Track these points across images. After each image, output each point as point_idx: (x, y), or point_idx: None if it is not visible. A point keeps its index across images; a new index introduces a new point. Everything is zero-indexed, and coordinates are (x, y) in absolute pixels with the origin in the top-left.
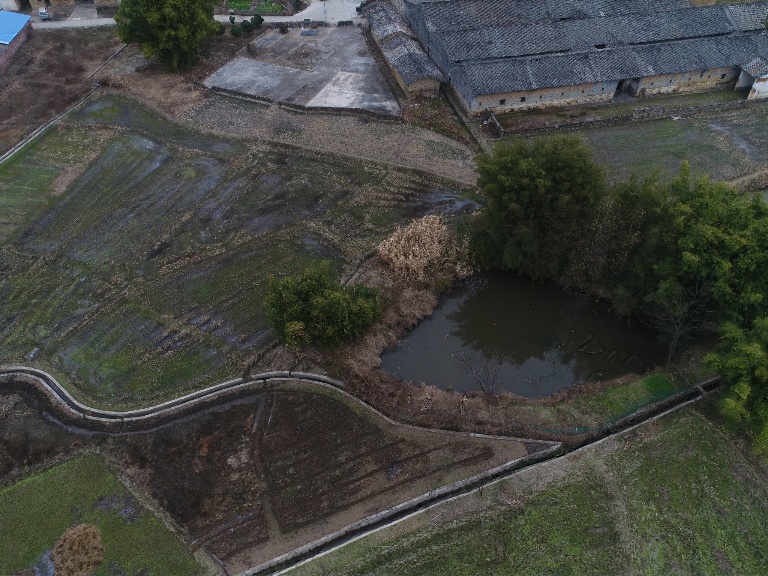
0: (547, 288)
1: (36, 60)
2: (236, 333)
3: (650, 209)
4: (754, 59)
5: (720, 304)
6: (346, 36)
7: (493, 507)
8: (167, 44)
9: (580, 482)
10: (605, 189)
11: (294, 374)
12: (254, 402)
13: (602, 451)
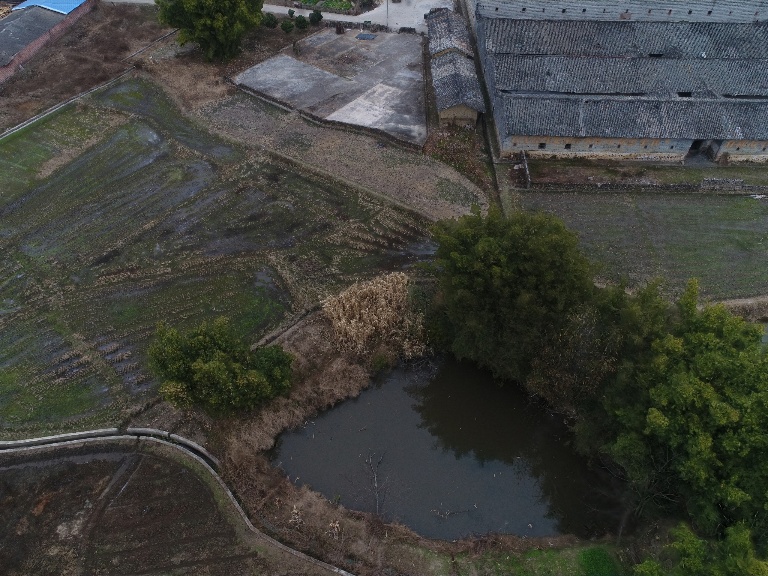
0: (508, 392)
1: (90, 33)
2: (137, 371)
3: (628, 335)
4: None
5: (692, 487)
6: (403, 44)
7: None
8: (202, 33)
9: None
10: (585, 293)
11: (173, 437)
12: (118, 461)
13: None
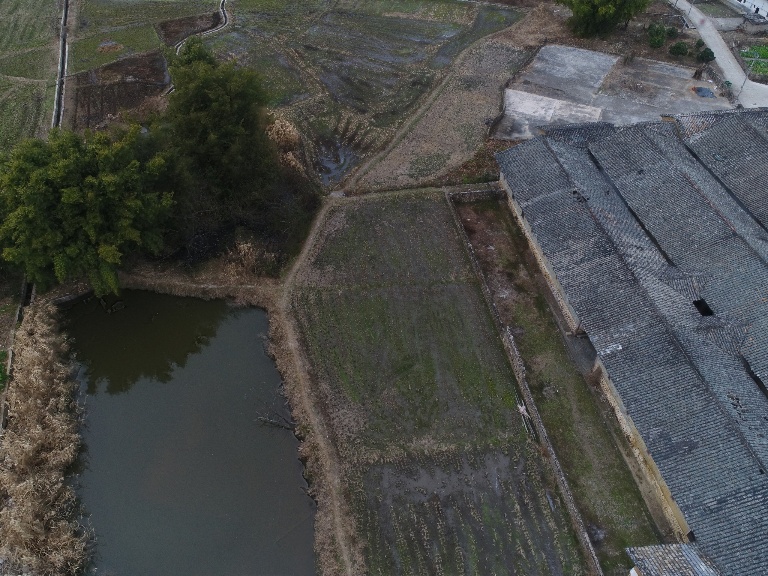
0: None
1: None
2: None
3: None
4: (717, 572)
5: None
6: None
7: None
8: None
9: None
10: None
11: None
12: (164, 81)
13: None
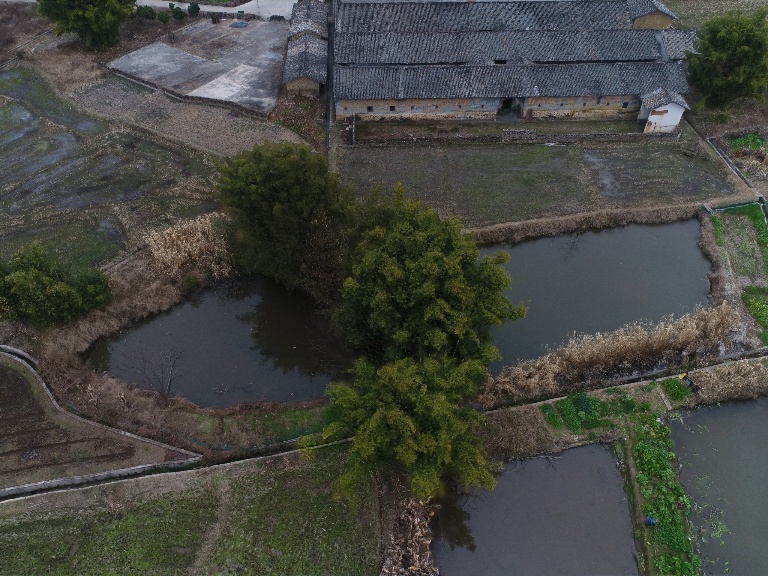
0: (298, 300)
1: None
2: None
3: None
4: (656, 89)
5: (385, 338)
6: (272, 31)
7: (94, 507)
8: (76, 23)
9: (195, 498)
10: (328, 204)
11: (3, 347)
12: None
13: (236, 472)
